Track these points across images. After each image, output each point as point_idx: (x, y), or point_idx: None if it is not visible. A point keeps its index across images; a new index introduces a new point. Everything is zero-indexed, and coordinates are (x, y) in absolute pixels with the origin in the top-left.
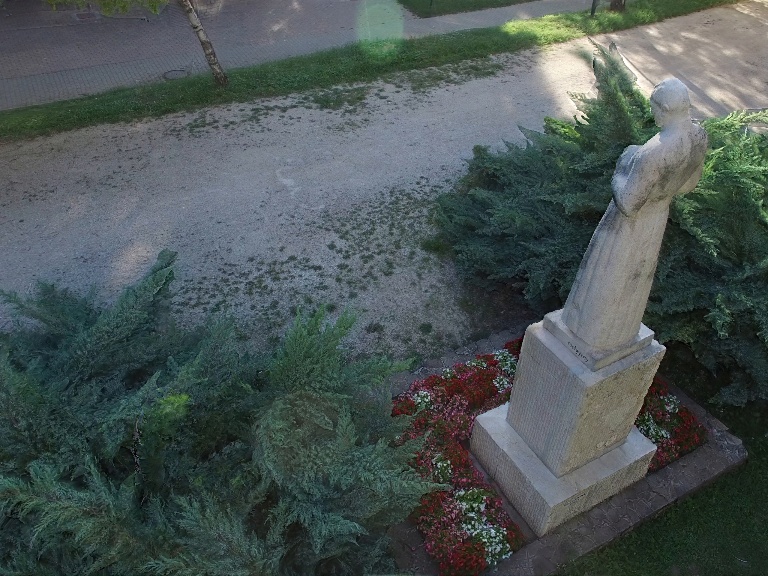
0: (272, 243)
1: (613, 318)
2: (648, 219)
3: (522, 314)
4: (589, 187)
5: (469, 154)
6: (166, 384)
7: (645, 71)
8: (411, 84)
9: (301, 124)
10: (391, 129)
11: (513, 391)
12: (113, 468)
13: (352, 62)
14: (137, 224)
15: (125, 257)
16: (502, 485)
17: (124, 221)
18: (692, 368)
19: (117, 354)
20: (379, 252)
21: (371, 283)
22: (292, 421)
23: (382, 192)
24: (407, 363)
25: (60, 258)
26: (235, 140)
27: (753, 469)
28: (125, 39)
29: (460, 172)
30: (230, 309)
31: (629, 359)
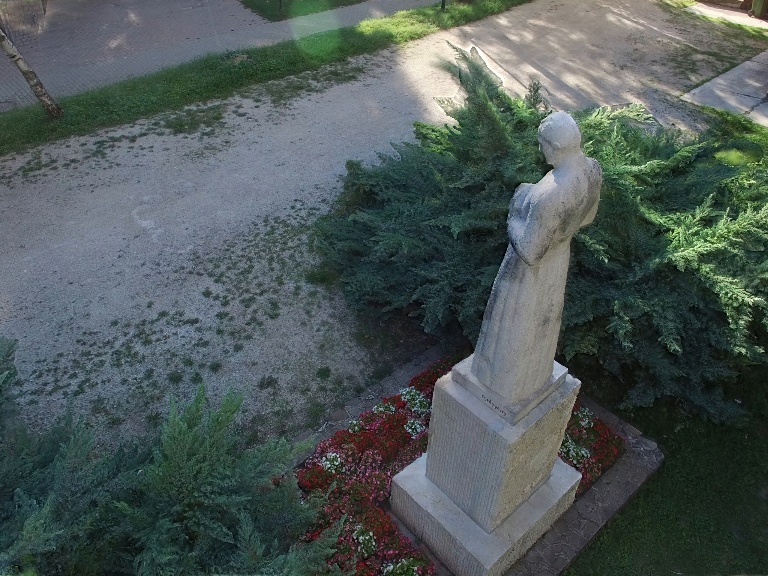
0: (137, 299)
1: (527, 367)
2: (551, 263)
3: (422, 340)
4: (473, 204)
5: (342, 168)
6: (15, 528)
7: (502, 62)
8: (270, 97)
9: (154, 154)
10: (255, 149)
11: (429, 447)
12: None
13: (203, 78)
14: None
15: None
16: (431, 546)
17: None
18: (596, 371)
19: None
20: (261, 292)
21: (257, 330)
22: None
23: (255, 222)
24: (309, 441)
25: None
26: (79, 181)
27: (670, 470)
28: None
29: (335, 189)
30: (96, 388)
31: (547, 402)
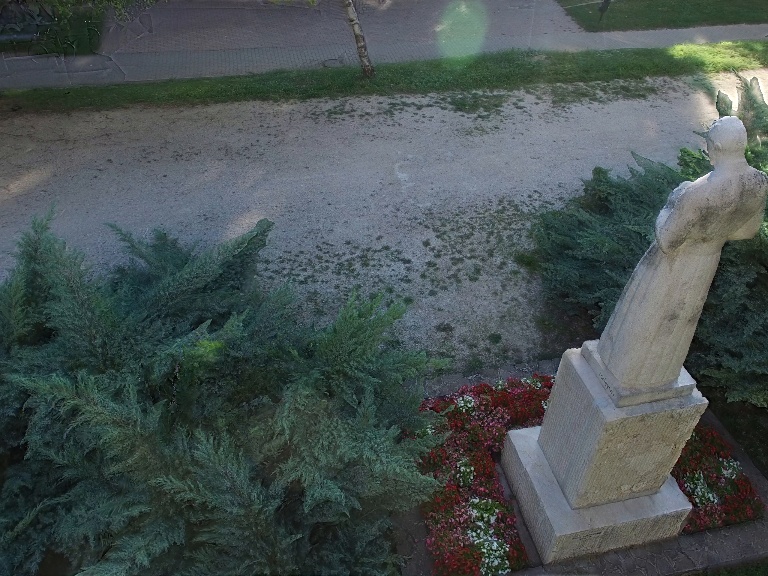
0: (371, 231)
1: (644, 357)
2: (690, 260)
3: None
4: None
5: None
6: None
7: None
8: (553, 97)
9: (432, 123)
10: (519, 140)
11: (546, 413)
12: (159, 395)
13: (498, 69)
14: (258, 194)
15: (240, 221)
16: (521, 504)
17: (248, 189)
18: None
19: (196, 301)
20: (470, 257)
21: (454, 285)
22: (326, 392)
23: (491, 200)
24: (443, 362)
25: (187, 213)
26: (366, 130)
27: None
28: (298, 26)
29: (577, 192)
30: (316, 284)
31: (661, 404)
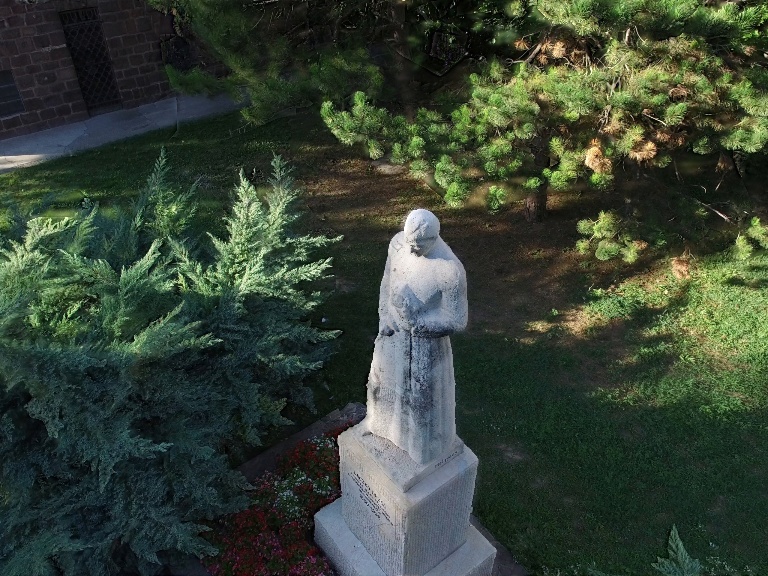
0: None
1: None
2: None
3: None
4: (88, 427)
5: None
6: None
7: None
8: None
9: None
10: None
11: None
12: None
13: None
14: None
15: None
16: None
17: None
18: None
19: None
20: None
21: None
22: None
23: None
24: None
25: None
26: None
27: None
28: None
29: None
30: None
31: None
